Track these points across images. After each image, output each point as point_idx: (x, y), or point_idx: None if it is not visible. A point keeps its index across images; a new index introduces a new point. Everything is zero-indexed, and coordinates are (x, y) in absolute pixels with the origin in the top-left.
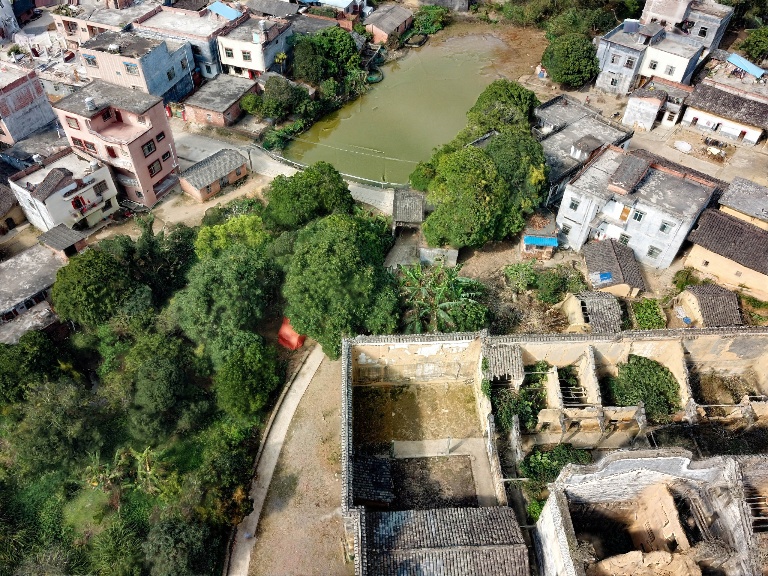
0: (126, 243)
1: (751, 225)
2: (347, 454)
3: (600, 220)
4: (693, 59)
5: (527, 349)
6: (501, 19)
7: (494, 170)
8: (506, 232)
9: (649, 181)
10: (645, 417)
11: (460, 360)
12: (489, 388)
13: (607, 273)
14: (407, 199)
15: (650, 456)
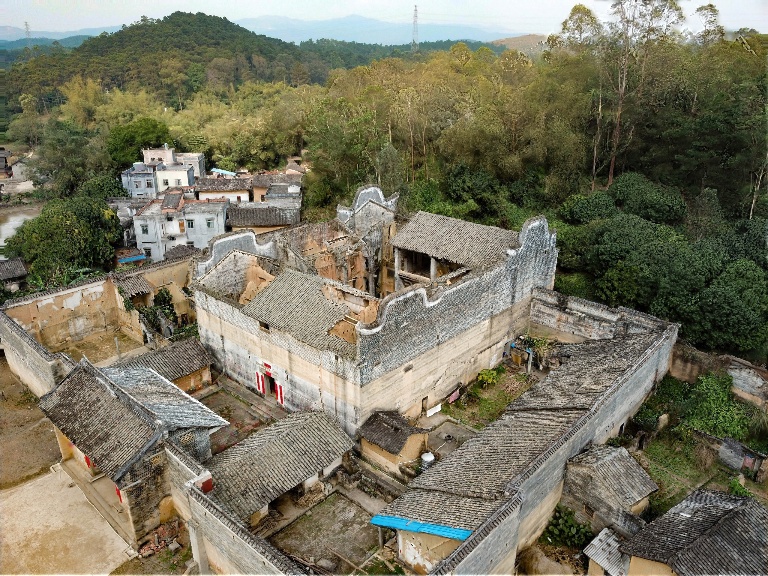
0: None
1: None
2: (33, 340)
3: (168, 236)
4: (190, 173)
5: (148, 279)
6: (35, 201)
7: (73, 216)
8: (103, 260)
9: (188, 207)
10: None
11: (102, 308)
12: (131, 303)
13: None
14: (6, 264)
15: (232, 234)
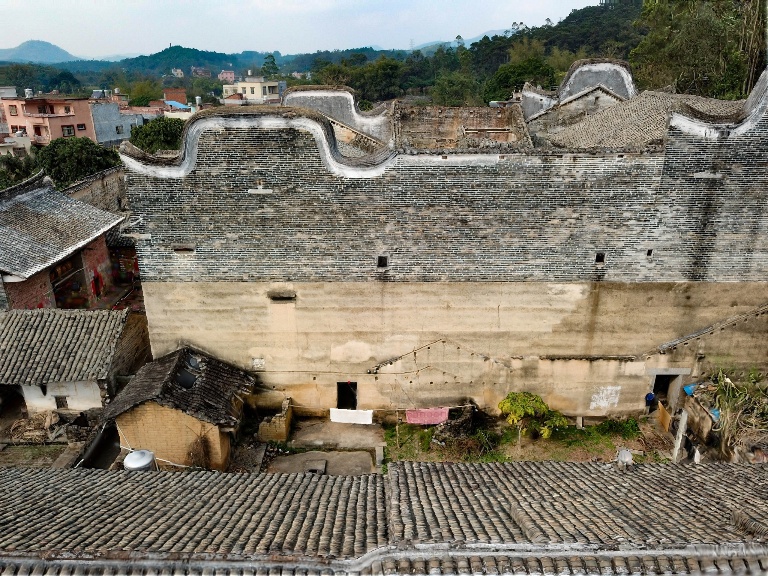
0: (16, 159)
1: None
2: None
3: None
4: None
5: None
6: None
7: None
8: None
9: None
10: None
11: None
12: None
13: None
14: None
15: (315, 88)
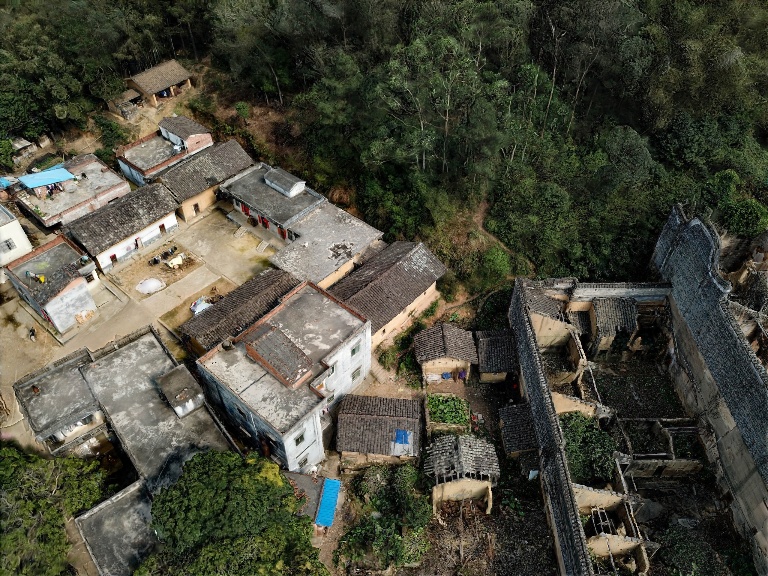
0: None
1: (354, 275)
2: None
3: None
4: None
5: None
6: None
7: None
8: None
9: None
10: (627, 455)
11: None
12: None
13: (398, 434)
14: None
15: None
